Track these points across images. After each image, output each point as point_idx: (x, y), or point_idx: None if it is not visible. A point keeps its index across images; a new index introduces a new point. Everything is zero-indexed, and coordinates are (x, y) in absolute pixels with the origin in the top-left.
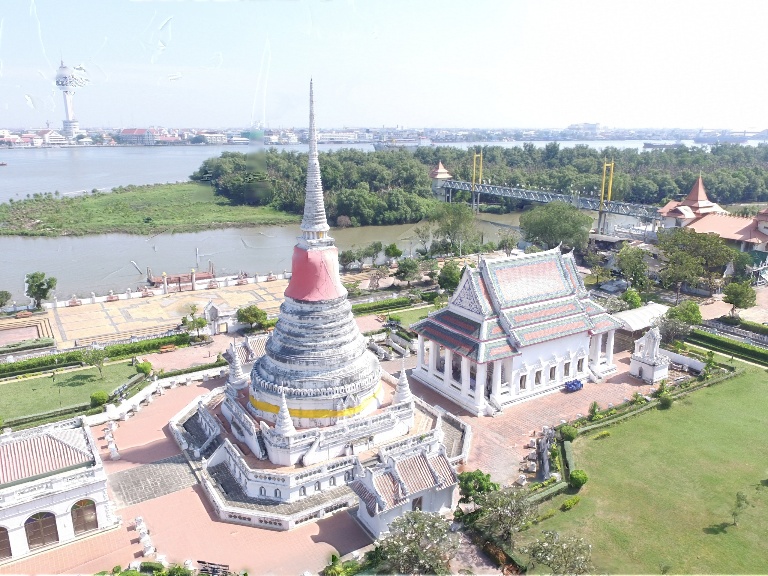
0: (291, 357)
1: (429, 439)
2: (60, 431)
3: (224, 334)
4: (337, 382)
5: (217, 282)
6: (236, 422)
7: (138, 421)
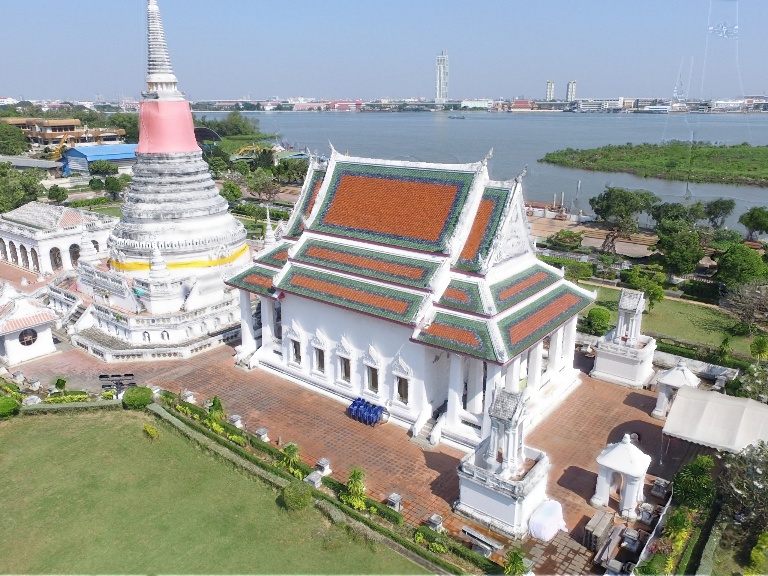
0: None
1: (125, 323)
2: (77, 213)
3: None
4: None
5: None
6: None
7: None
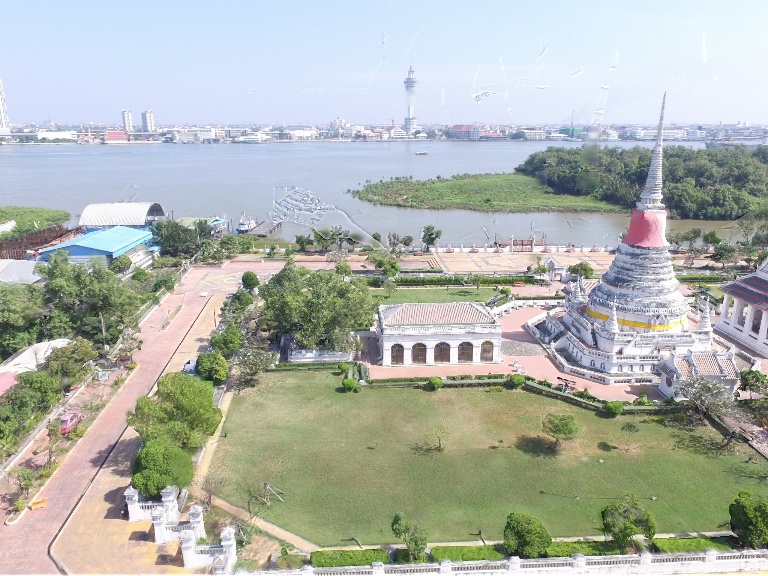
0: (622, 284)
1: None
2: None
3: (558, 281)
4: (654, 305)
5: (550, 248)
6: (575, 324)
7: (504, 320)
